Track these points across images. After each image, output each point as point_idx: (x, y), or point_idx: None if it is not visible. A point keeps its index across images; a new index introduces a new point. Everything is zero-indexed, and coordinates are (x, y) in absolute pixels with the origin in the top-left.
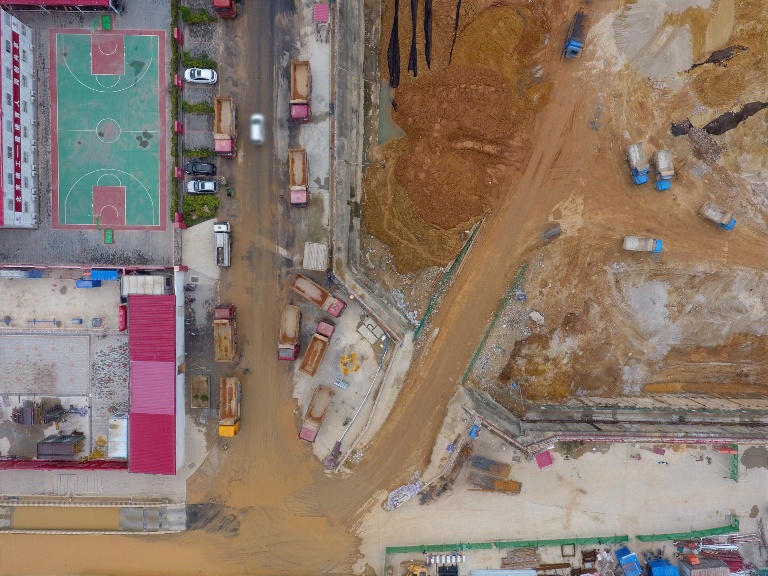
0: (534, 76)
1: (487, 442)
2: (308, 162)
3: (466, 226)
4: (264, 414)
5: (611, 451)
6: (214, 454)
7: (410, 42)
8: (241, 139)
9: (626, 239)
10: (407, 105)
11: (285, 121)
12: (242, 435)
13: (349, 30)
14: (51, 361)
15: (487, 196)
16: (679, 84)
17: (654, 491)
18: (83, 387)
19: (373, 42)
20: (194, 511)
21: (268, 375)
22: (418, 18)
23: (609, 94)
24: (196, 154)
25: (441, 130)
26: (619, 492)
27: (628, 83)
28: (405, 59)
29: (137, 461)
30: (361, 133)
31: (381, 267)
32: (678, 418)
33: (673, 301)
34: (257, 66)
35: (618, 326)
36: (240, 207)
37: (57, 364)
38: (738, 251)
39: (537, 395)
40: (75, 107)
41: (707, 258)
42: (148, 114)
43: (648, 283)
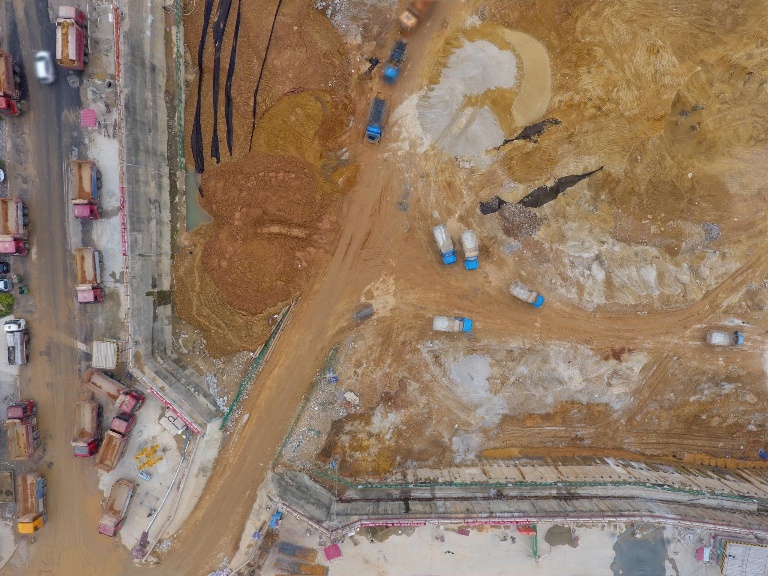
0: (340, 158)
1: (293, 528)
2: (102, 257)
3: (274, 311)
4: (71, 506)
5: (416, 533)
6: (23, 547)
7: (211, 129)
8: (33, 236)
9: (434, 320)
10: (211, 192)
11: None
12: (50, 527)
13: (140, 123)
14: None
15: (297, 279)
16: (486, 163)
17: (460, 571)
18: None
19: (176, 129)
20: None
21: (73, 468)
22: (219, 104)
23: (416, 175)
24: None
25: (242, 218)
26: (426, 573)
27: (435, 163)
28: (207, 146)
29: None
30: (166, 221)
31: (194, 352)
32: (496, 492)
33: (496, 373)
34: (46, 162)
35: (441, 400)
36: (36, 303)
37: None
38: (551, 326)
39: (361, 471)
40: None
41: (520, 334)
42: None
43: (468, 357)
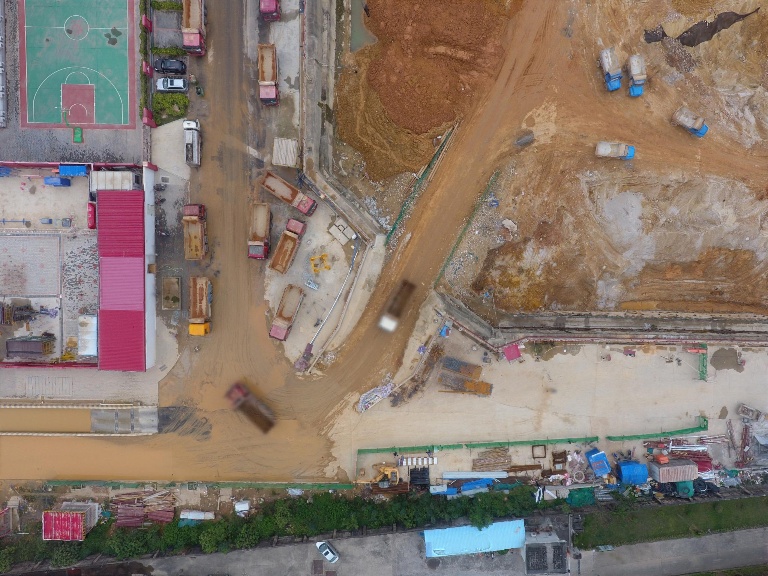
0: None
1: (458, 344)
2: (278, 61)
3: (438, 131)
4: (235, 316)
5: (582, 353)
6: (186, 357)
7: None
8: (211, 37)
9: (598, 145)
10: (379, 9)
11: (255, 19)
12: (214, 337)
13: None
14: (21, 262)
15: (460, 102)
16: None
17: (624, 392)
18: (53, 288)
19: None
20: (166, 414)
21: (239, 277)
22: None
23: None
24: (165, 51)
25: (413, 33)
26: (589, 394)
27: None
28: None
29: (107, 358)
30: (333, 38)
31: (354, 174)
32: (650, 326)
33: (647, 213)
34: None
35: (592, 238)
36: (210, 107)
37: (27, 265)
38: (711, 160)
39: (511, 306)
40: (43, 3)
41: (680, 166)
42: (116, 11)
43: (622, 194)
